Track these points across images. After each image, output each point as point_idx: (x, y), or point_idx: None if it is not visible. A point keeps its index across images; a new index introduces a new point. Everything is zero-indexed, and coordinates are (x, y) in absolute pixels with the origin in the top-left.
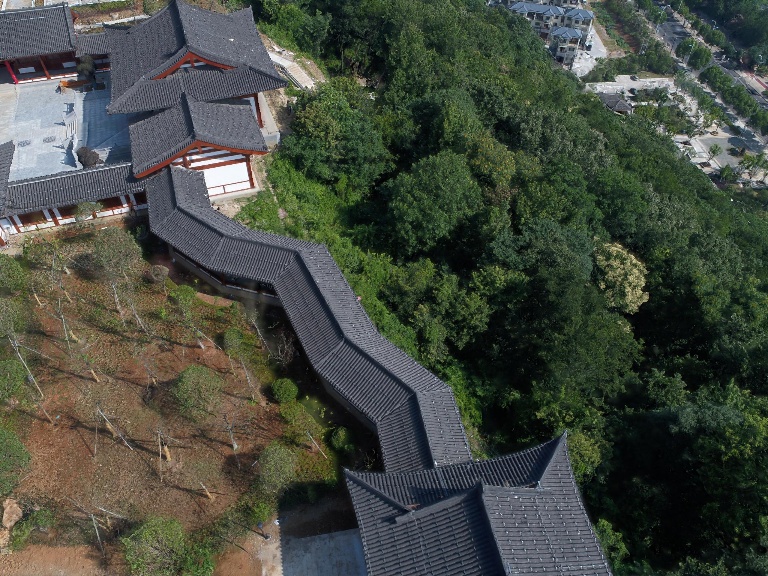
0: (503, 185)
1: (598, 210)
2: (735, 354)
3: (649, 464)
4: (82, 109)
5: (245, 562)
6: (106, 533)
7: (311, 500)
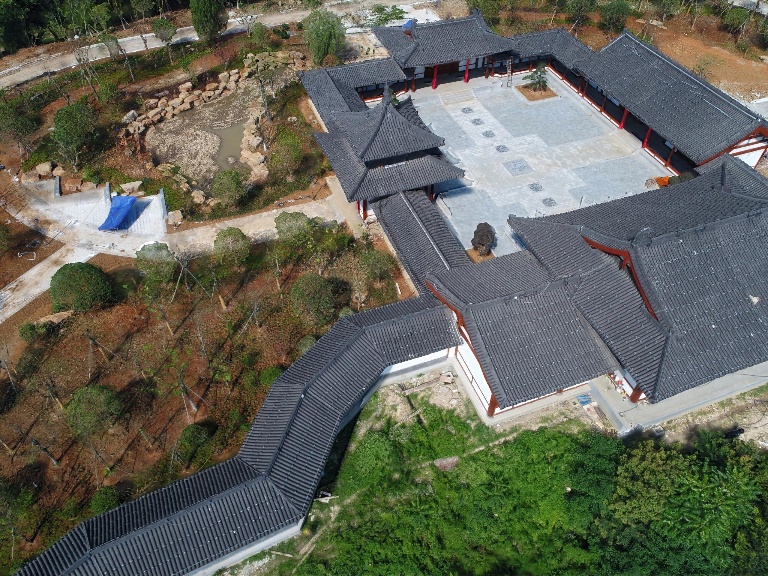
0: None
1: None
2: None
3: None
4: None
5: None
6: None
7: None
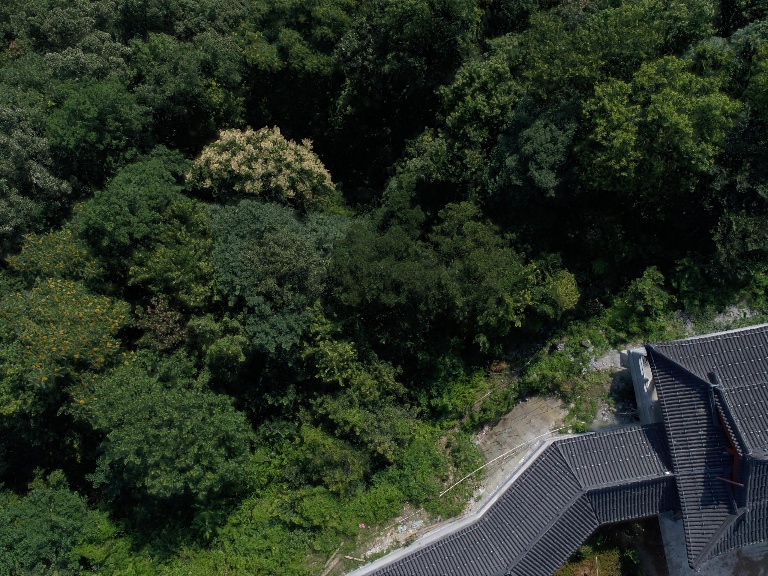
0: (125, 312)
1: (170, 175)
2: (397, 67)
3: (555, 216)
4: None
5: None
6: None
7: None
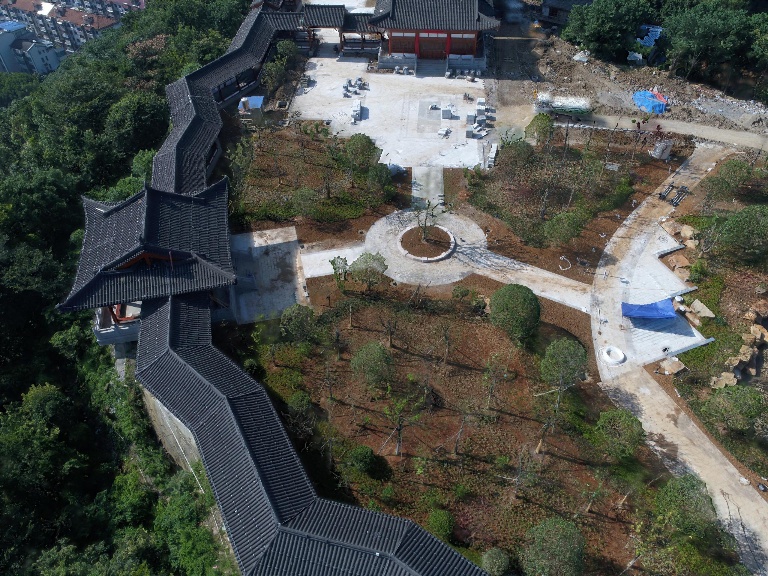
0: None
1: None
2: None
3: None
4: None
5: (321, 301)
6: (419, 304)
7: None
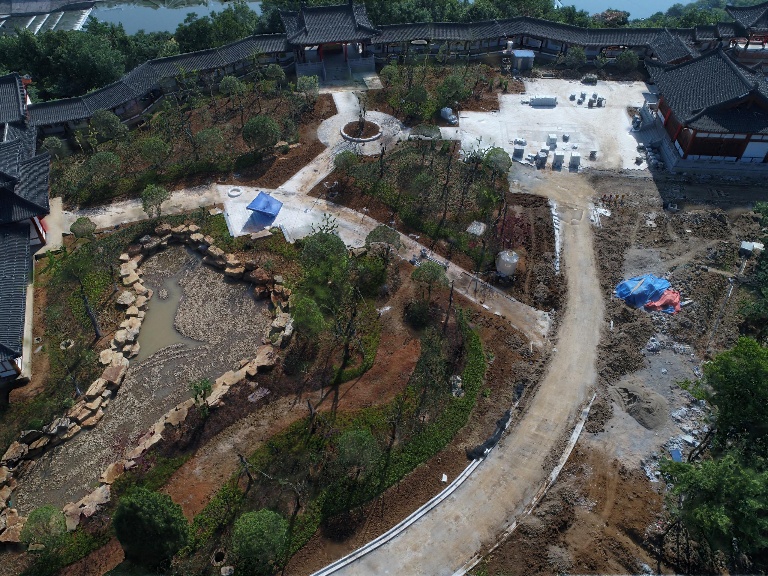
0: None
1: None
2: None
3: None
4: None
5: None
6: None
7: (285, 83)
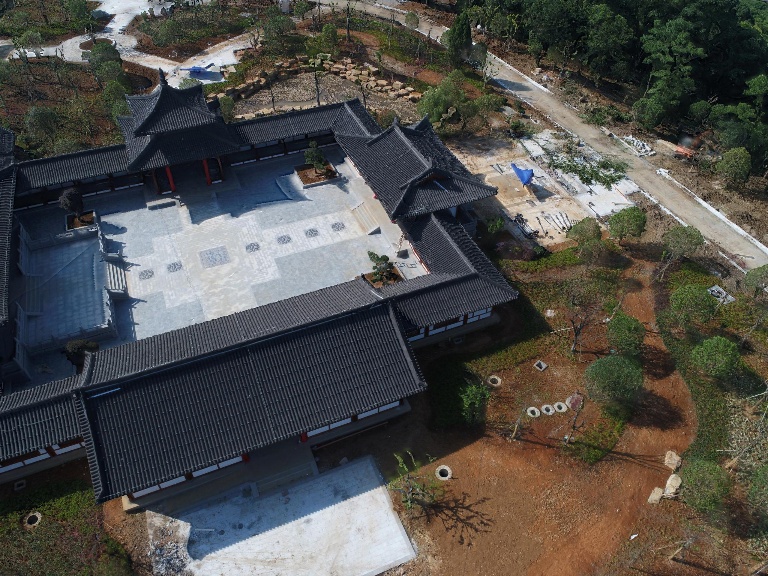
0: None
1: None
2: None
3: None
4: (106, 314)
5: None
6: None
7: None
